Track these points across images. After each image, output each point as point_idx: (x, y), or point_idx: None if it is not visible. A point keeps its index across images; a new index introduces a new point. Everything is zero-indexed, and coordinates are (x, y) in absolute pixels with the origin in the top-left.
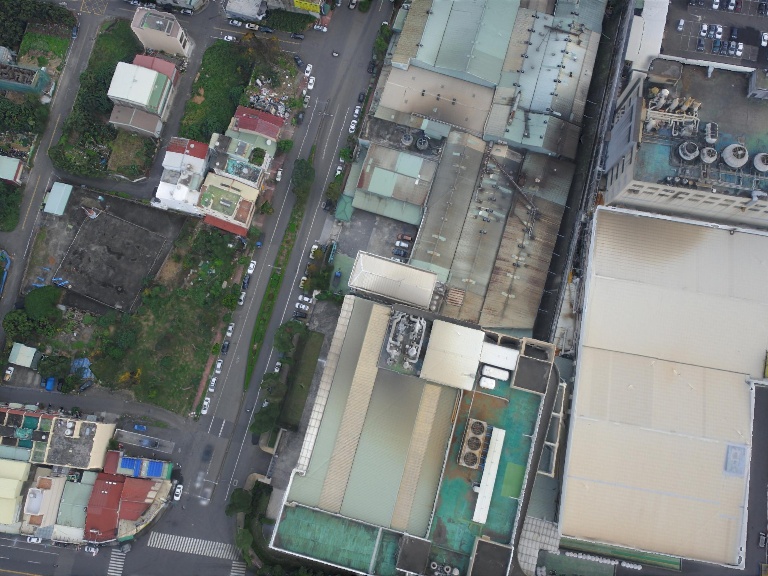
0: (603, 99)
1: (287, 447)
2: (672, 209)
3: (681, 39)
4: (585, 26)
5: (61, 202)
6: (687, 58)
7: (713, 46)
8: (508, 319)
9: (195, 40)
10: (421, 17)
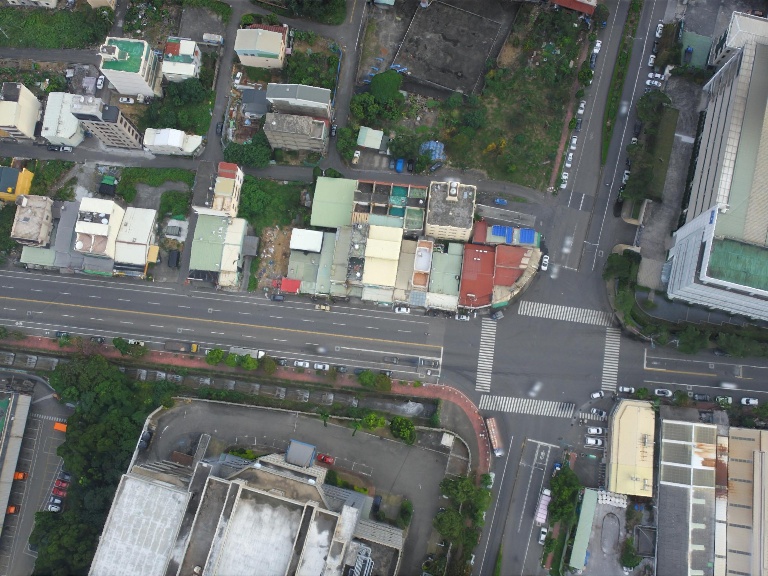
0: None
1: (652, 218)
2: None
3: None
4: None
5: None
6: None
7: None
8: None
9: None
10: None
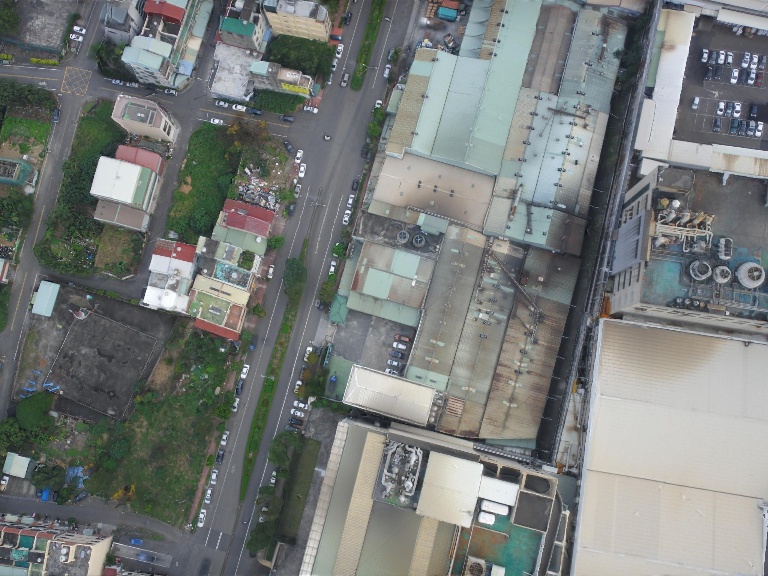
0: (611, 188)
1: (285, 560)
2: (683, 320)
3: (696, 118)
4: (592, 107)
5: (49, 303)
6: (702, 143)
7: (730, 126)
8: (510, 430)
9: (180, 123)
10: (416, 101)
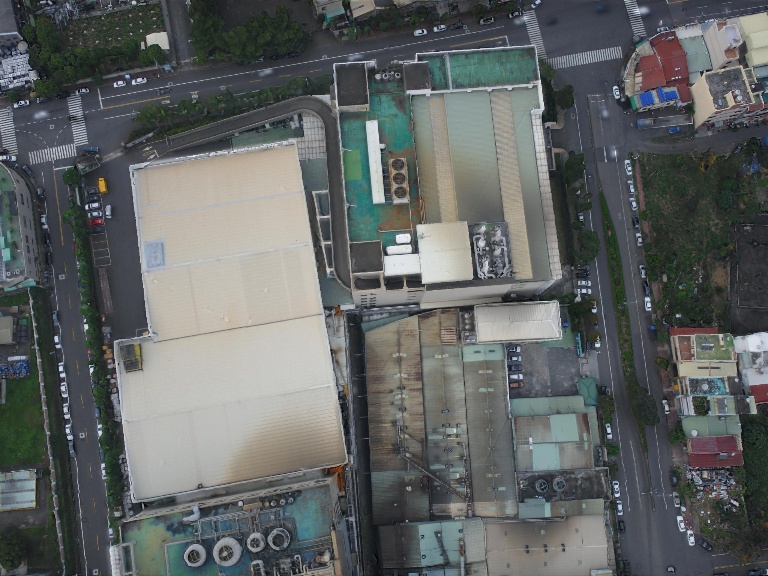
0: None
1: None
2: None
3: None
4: None
5: None
6: None
7: None
8: (392, 331)
9: None
10: None
